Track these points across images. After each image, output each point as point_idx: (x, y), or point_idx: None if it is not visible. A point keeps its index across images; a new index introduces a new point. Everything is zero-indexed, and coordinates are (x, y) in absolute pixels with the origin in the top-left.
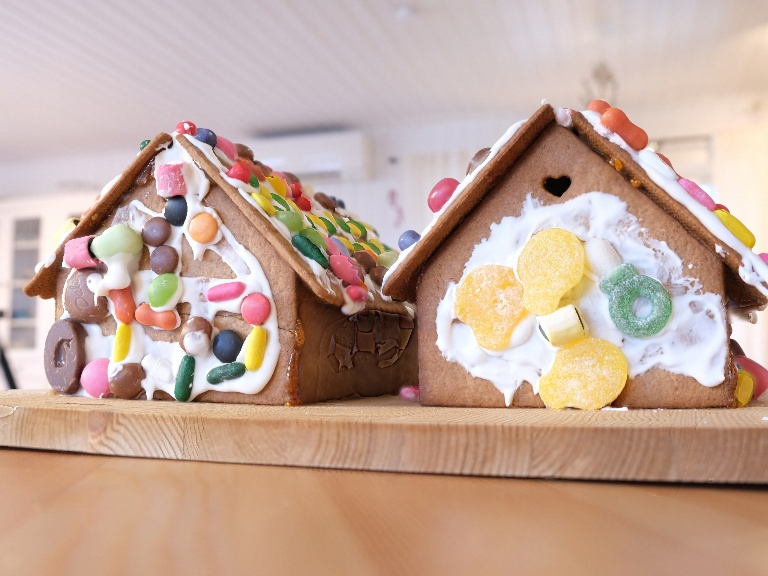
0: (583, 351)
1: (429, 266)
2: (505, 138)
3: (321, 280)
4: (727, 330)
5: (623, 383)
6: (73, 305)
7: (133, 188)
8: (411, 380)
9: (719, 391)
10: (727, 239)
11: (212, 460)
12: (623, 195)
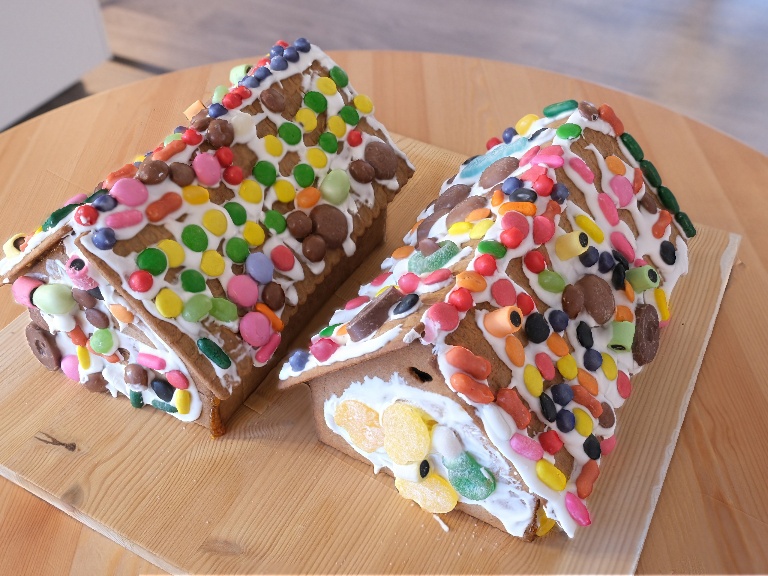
0: (425, 485)
1: None
2: (370, 348)
3: (225, 378)
4: (534, 512)
5: (451, 509)
6: (37, 323)
7: (53, 250)
8: (366, 254)
9: None
10: (536, 493)
11: None
12: None
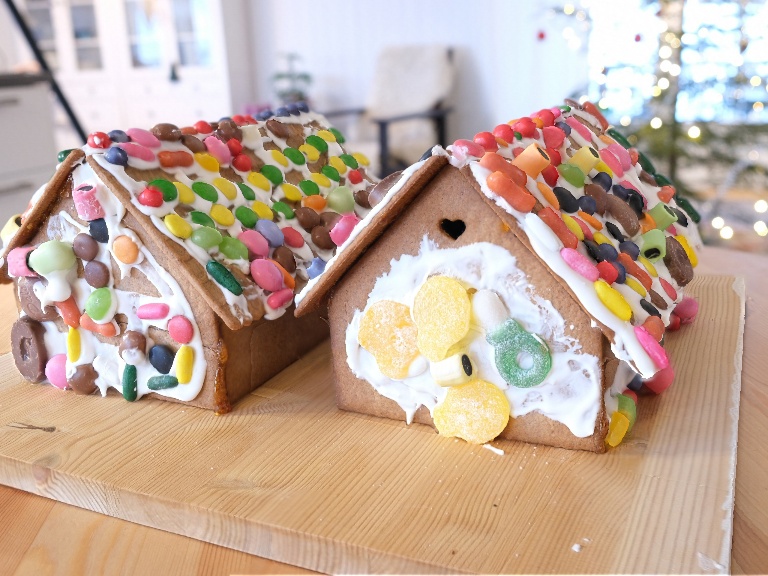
0: (469, 394)
1: (337, 290)
2: (397, 186)
3: (235, 308)
4: (601, 388)
5: (504, 425)
6: (26, 309)
7: (59, 199)
8: None
9: (589, 440)
10: (600, 319)
11: (130, 521)
12: (513, 249)
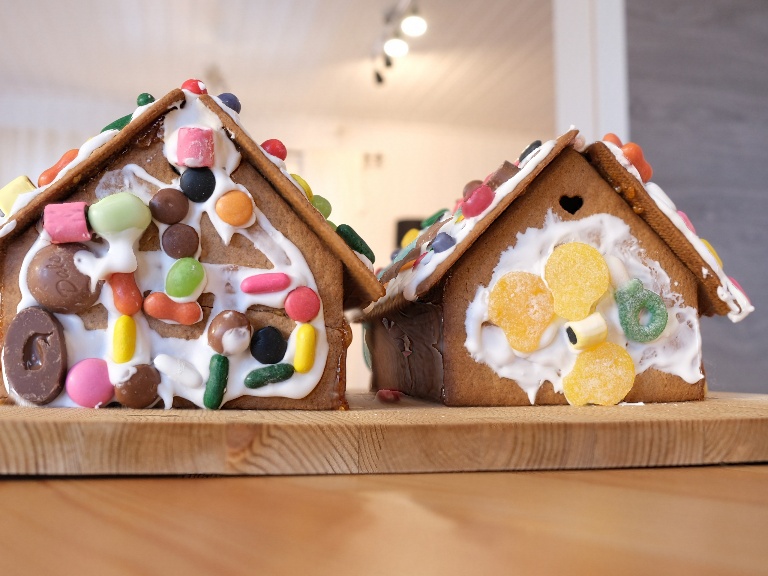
0: (604, 354)
1: (457, 269)
2: (542, 155)
3: None
4: None
5: (633, 381)
6: (52, 289)
7: (128, 149)
8: None
9: (696, 387)
10: (714, 264)
11: (395, 471)
12: (627, 219)
